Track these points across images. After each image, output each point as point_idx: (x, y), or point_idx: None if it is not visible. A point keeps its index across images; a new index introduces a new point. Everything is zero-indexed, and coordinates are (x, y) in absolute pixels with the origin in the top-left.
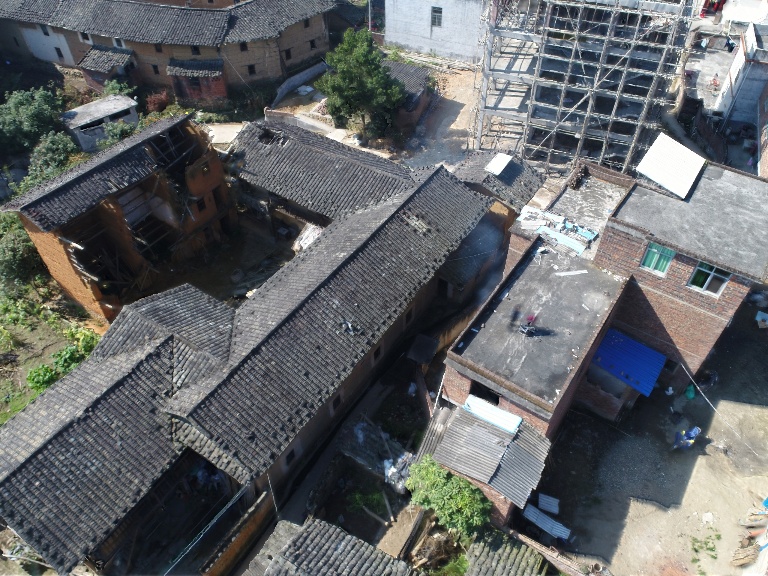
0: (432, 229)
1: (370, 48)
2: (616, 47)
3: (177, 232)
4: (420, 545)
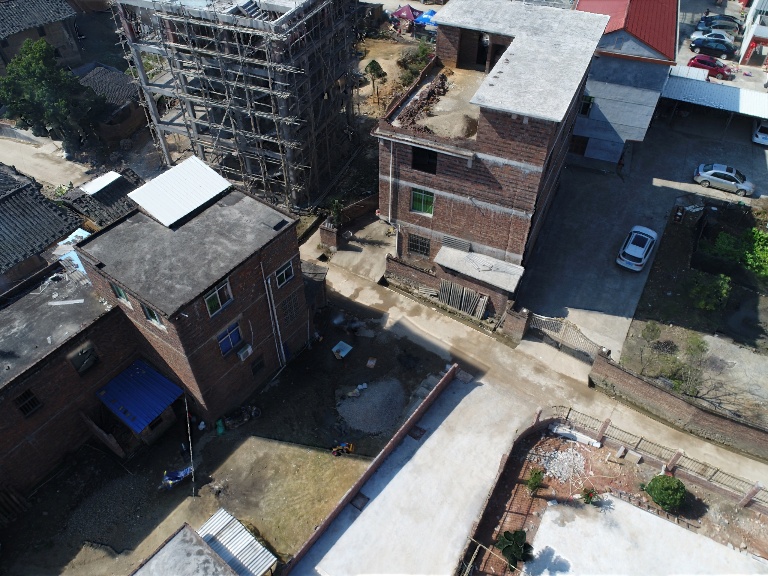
0: None
1: None
2: (236, 64)
3: None
4: None
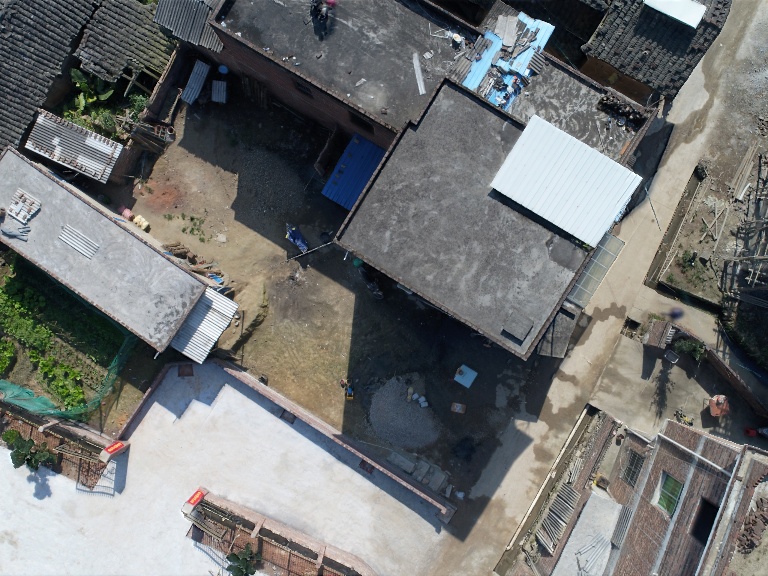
0: None
1: None
2: None
3: None
4: None
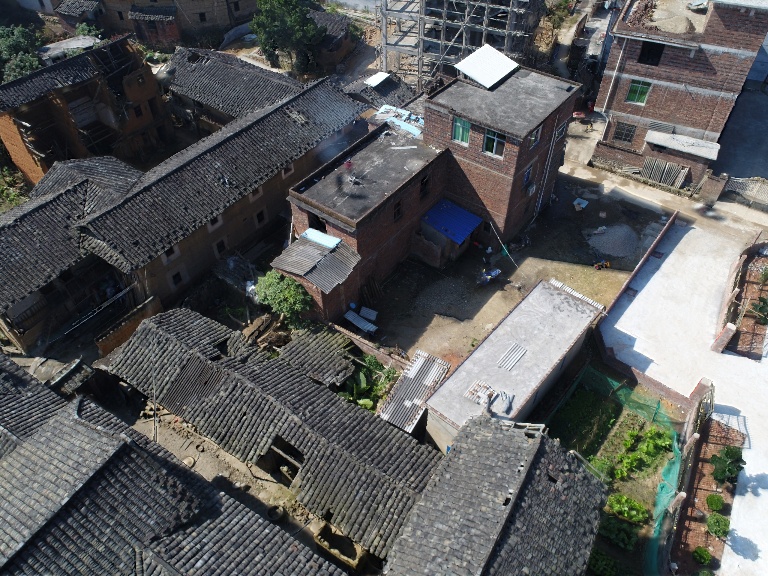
0: (310, 122)
1: (312, 4)
2: None
3: (117, 132)
4: (265, 336)
